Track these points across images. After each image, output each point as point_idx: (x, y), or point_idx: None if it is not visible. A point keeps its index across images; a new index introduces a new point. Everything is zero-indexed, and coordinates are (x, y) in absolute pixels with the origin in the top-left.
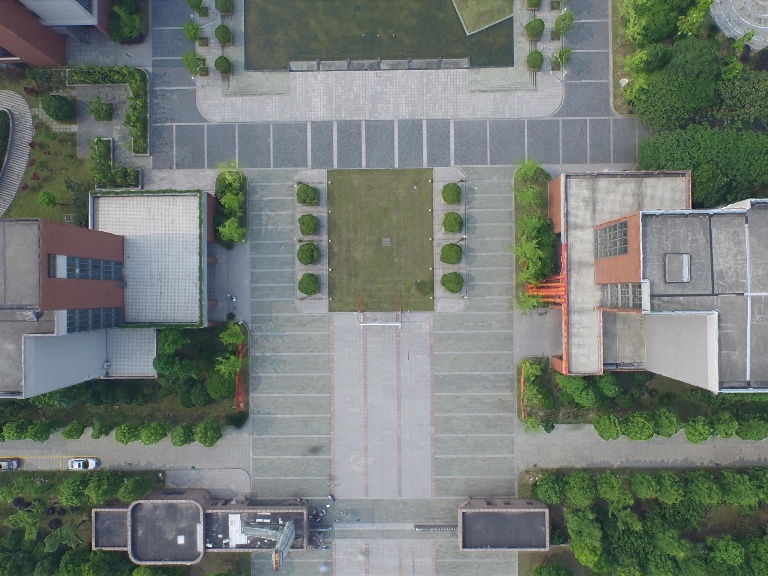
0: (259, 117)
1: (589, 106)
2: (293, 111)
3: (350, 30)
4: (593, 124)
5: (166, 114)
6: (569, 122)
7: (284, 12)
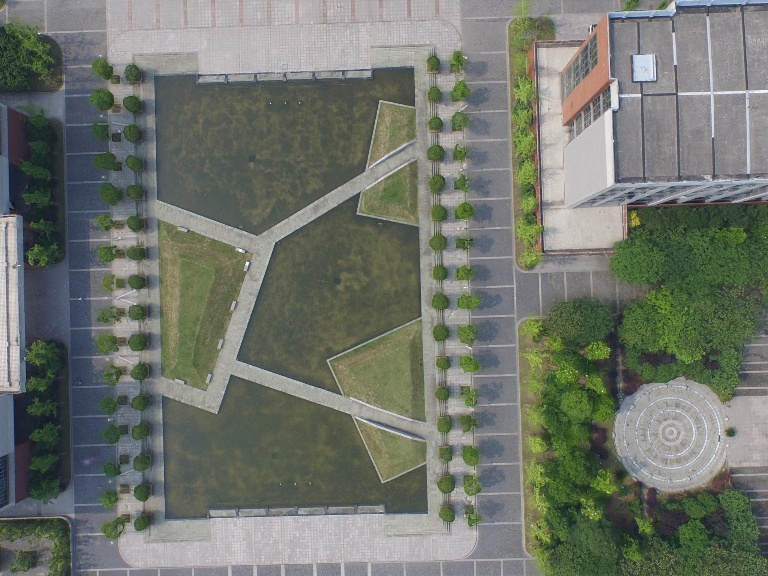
0: (181, 562)
1: (502, 548)
2: (214, 556)
3: (268, 477)
4: (506, 565)
5: (89, 560)
6: (483, 564)
7: (203, 460)
